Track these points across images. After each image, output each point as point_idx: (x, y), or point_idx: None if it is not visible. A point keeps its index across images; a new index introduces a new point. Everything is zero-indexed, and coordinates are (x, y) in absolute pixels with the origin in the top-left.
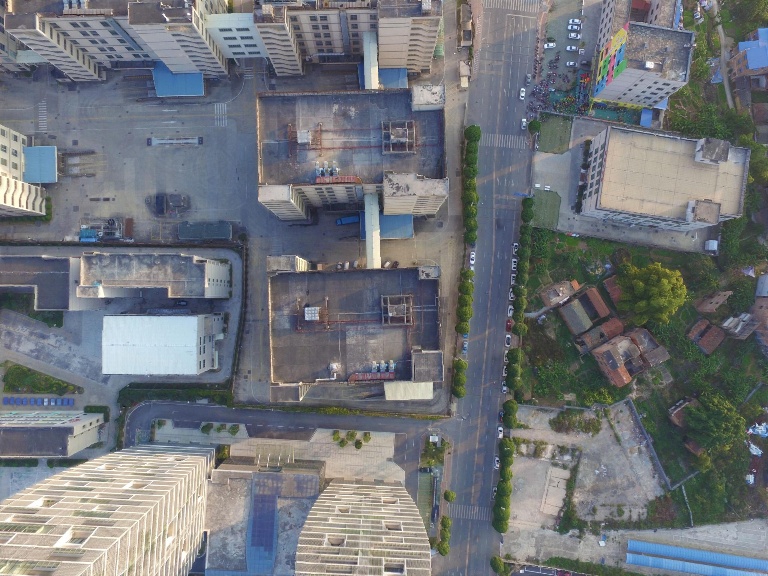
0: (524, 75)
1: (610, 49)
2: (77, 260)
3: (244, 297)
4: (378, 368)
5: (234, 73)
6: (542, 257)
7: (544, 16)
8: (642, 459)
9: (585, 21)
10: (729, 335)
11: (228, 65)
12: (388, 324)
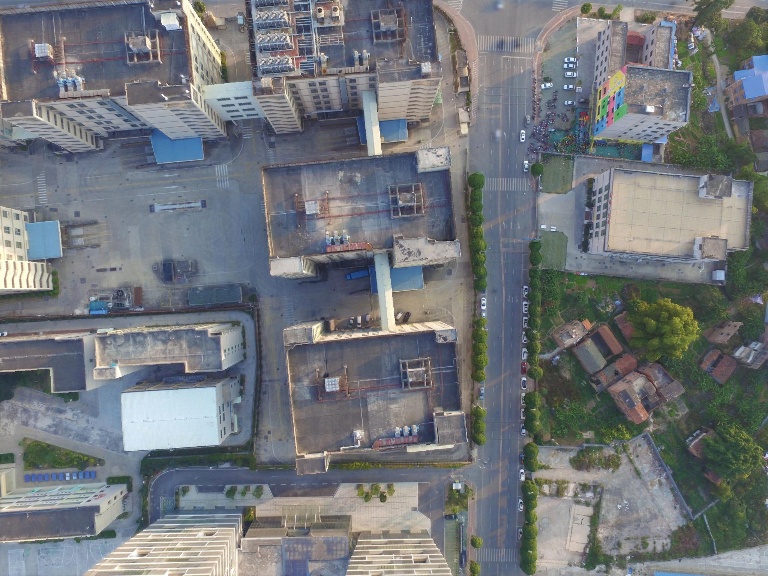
0: (523, 117)
1: (608, 90)
2: (90, 339)
3: (259, 358)
4: (401, 432)
5: (232, 133)
6: (553, 299)
7: (539, 56)
8: (663, 491)
9: (580, 58)
10: (741, 364)
11: (226, 127)
12: (408, 388)
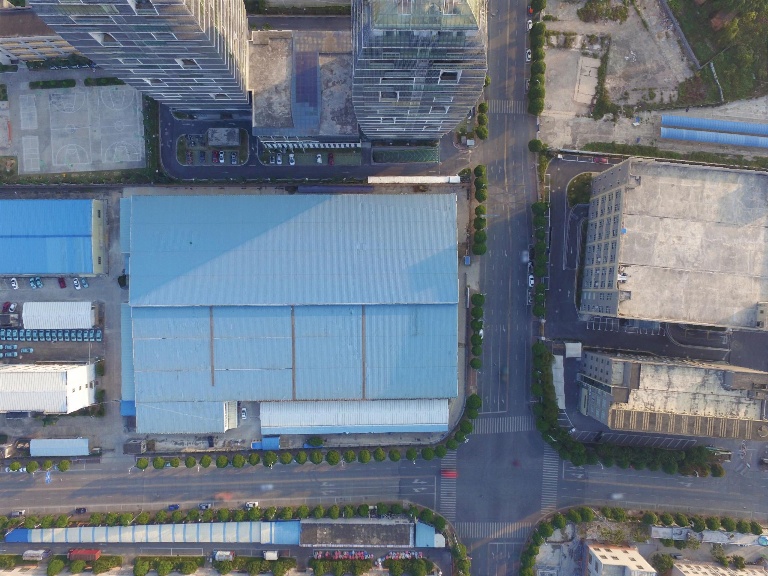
0: None
1: None
2: None
3: None
4: None
5: None
6: None
7: None
8: (670, 43)
9: None
10: None
11: None
12: None
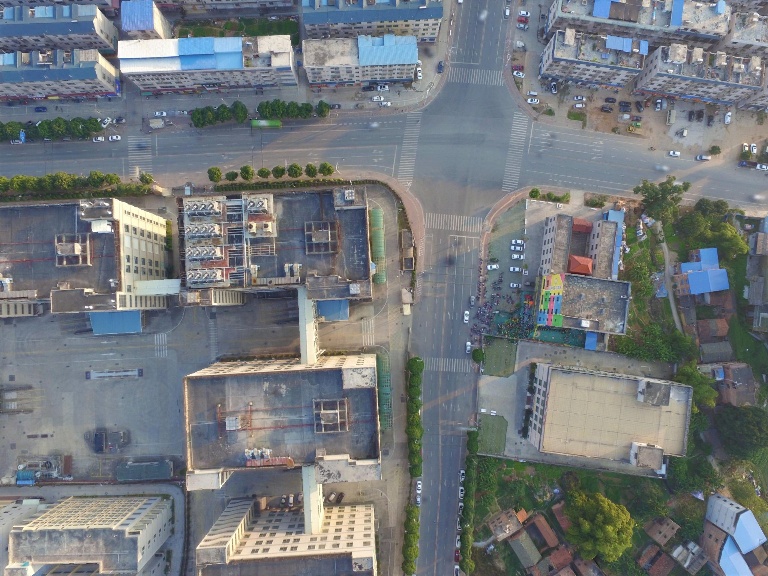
0: (468, 297)
1: (550, 286)
2: (8, 525)
3: (186, 535)
4: None
5: (174, 303)
6: (488, 489)
7: (487, 236)
8: None
9: (528, 241)
10: None
11: (167, 299)
12: None
